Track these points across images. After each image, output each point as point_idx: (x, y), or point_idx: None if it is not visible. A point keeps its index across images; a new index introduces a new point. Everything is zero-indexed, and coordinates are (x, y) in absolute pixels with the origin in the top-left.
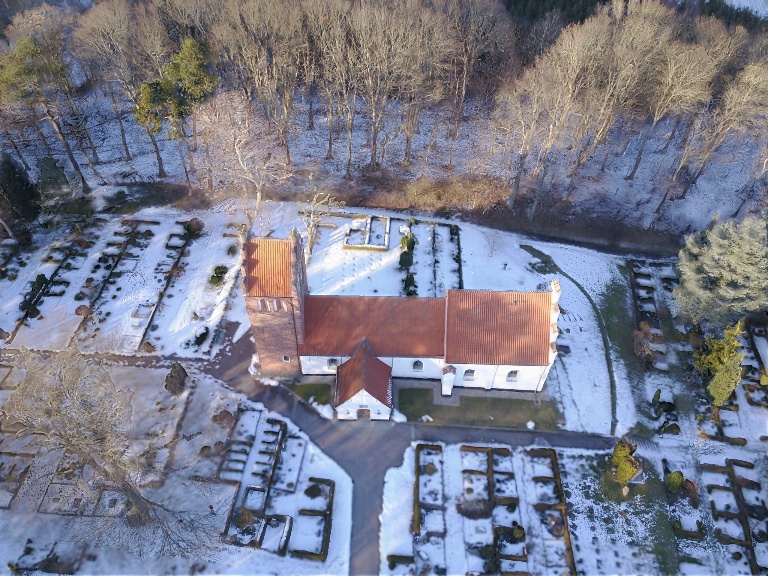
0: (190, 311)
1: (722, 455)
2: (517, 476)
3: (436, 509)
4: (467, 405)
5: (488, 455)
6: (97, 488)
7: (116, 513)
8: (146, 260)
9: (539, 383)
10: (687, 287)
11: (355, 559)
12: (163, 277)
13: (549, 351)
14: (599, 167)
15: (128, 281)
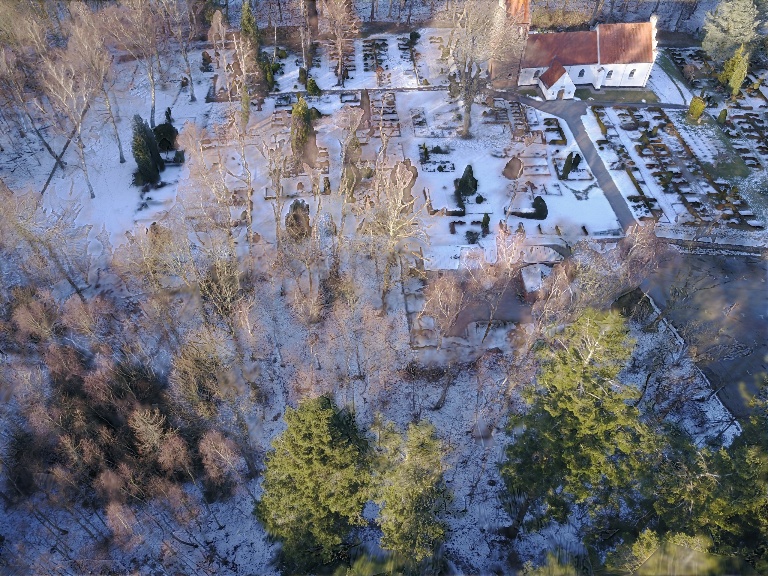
0: (436, 71)
1: (742, 113)
2: (644, 118)
3: (611, 128)
4: (609, 93)
5: (628, 110)
6: (439, 128)
7: (454, 136)
8: (392, 55)
9: (645, 80)
10: (710, 39)
11: (580, 144)
12: (408, 60)
13: (652, 54)
14: (634, 8)
15: (389, 63)
